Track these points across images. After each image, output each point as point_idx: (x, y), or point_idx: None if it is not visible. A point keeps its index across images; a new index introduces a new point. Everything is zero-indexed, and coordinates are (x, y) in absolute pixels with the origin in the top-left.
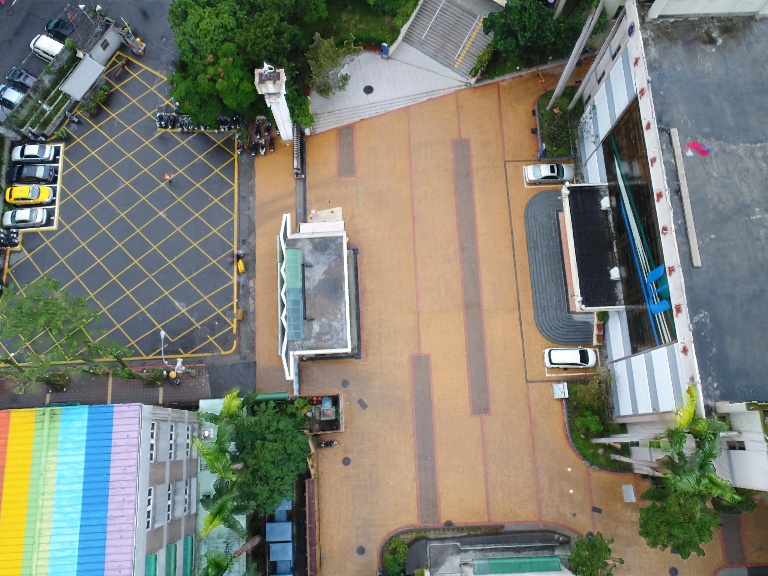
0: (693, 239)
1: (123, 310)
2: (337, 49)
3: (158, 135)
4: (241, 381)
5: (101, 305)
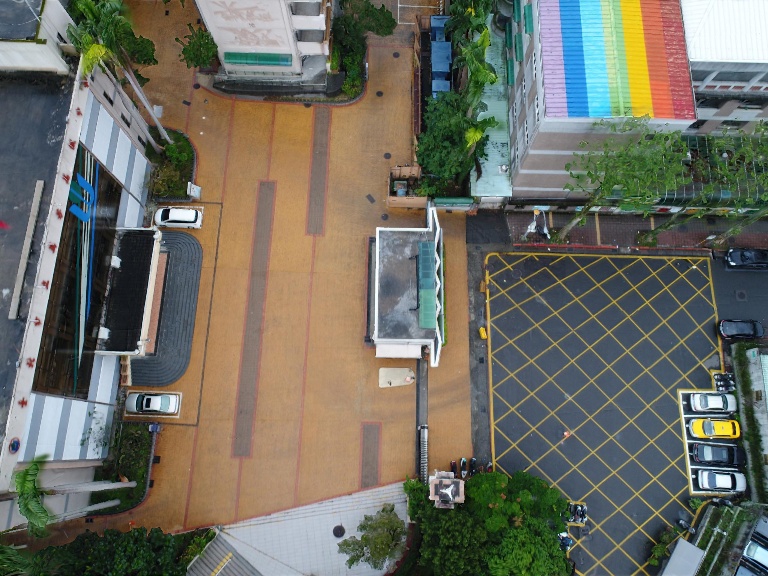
0: (35, 205)
1: (596, 300)
2: (370, 564)
3: (584, 497)
4: (480, 228)
5: (618, 306)
